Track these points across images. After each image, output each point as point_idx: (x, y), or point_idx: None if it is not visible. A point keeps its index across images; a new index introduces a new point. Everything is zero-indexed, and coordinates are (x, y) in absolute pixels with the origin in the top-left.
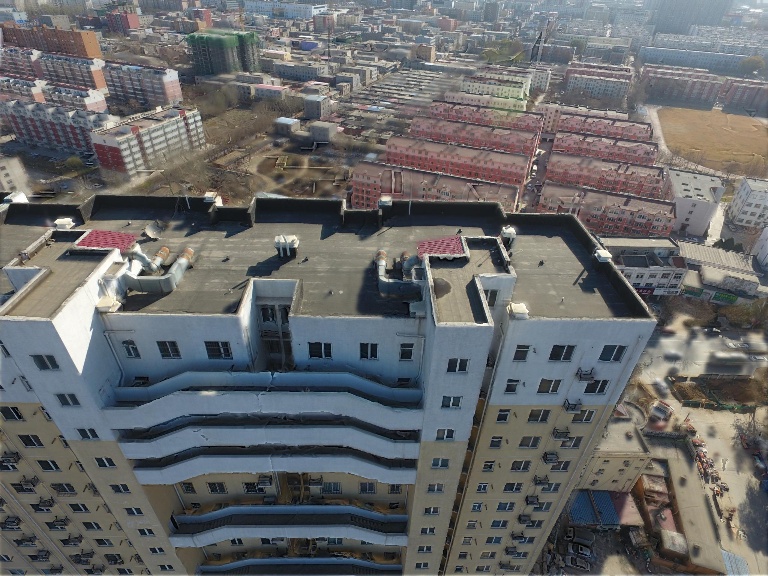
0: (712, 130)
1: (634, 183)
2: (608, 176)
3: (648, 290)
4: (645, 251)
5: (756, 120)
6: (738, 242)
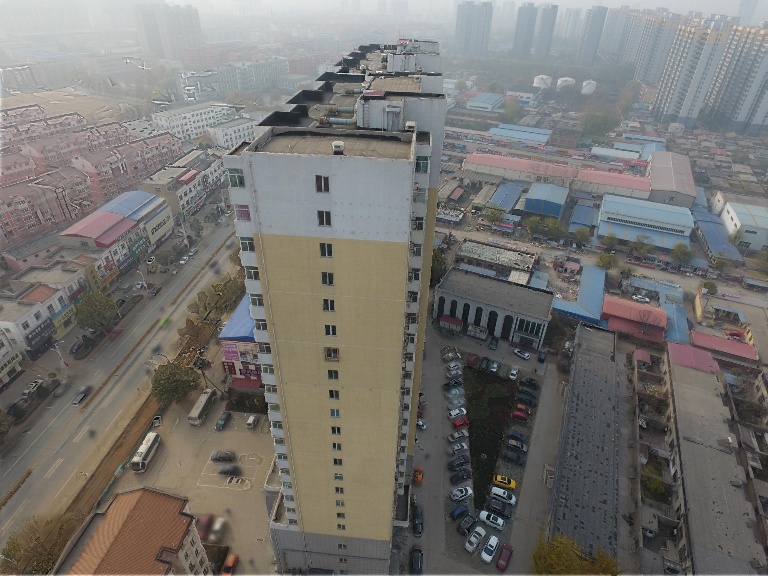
0: (48, 106)
1: (113, 139)
2: (92, 142)
3: (219, 181)
4: (197, 160)
5: (59, 92)
6: (204, 143)
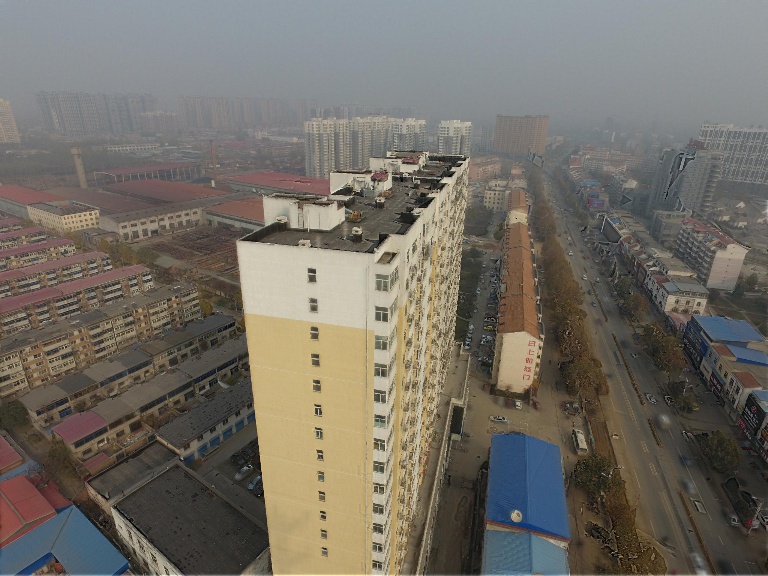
0: None
1: None
2: None
3: None
4: None
5: None
6: None
